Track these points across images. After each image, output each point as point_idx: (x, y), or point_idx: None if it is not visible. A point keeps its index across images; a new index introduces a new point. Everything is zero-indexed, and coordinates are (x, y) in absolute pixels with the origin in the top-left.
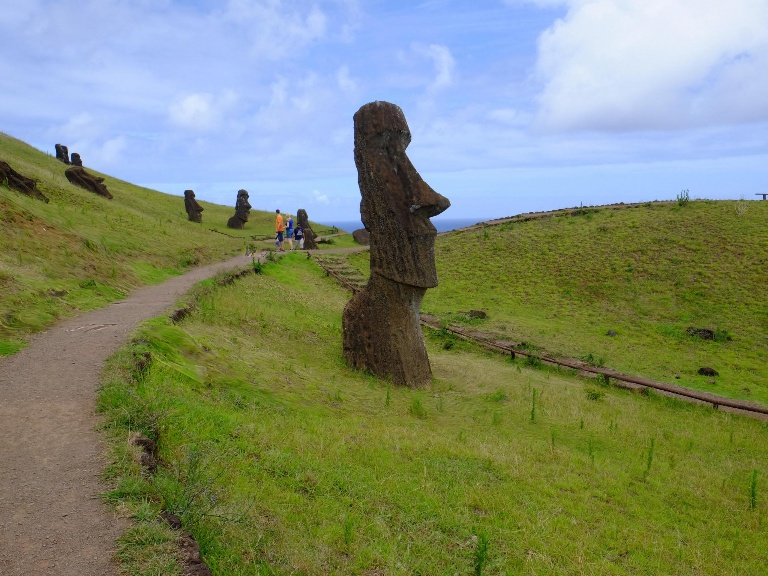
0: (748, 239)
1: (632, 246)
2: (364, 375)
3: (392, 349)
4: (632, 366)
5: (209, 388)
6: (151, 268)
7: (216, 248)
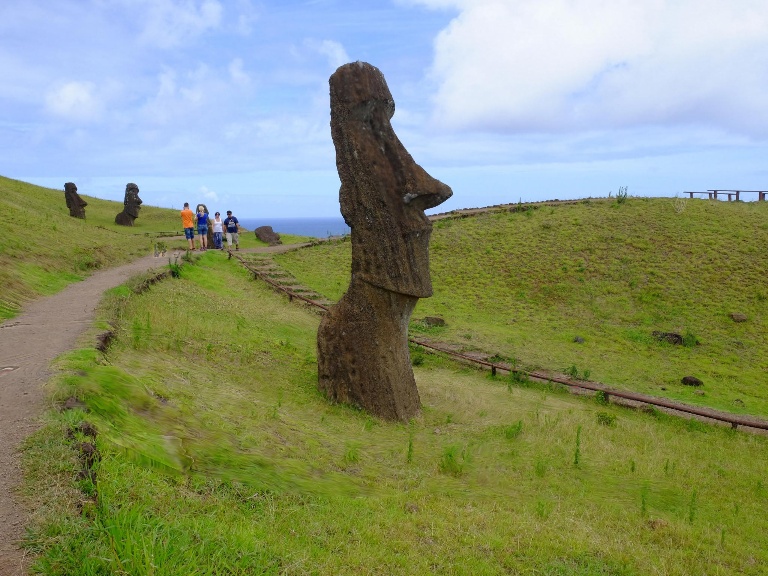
0: (693, 237)
1: (579, 245)
2: (349, 410)
3: (381, 375)
4: (613, 377)
5: None
6: (43, 272)
7: (119, 247)
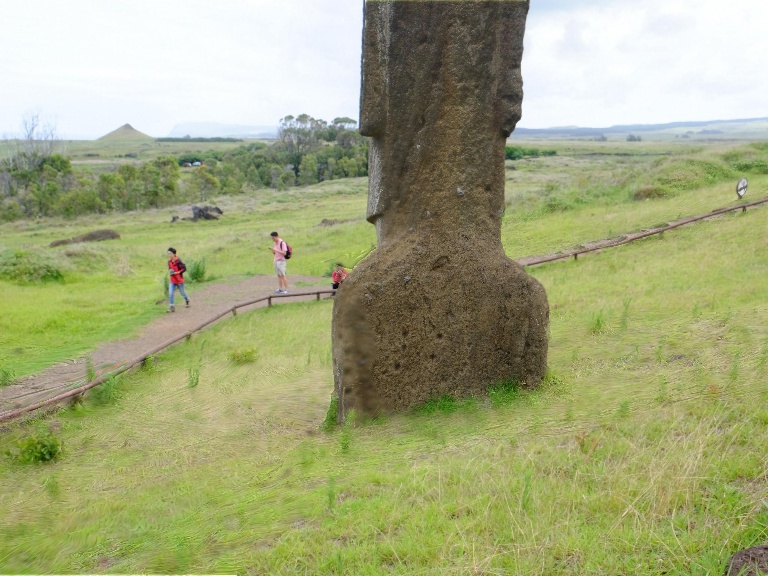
0: None
1: None
2: None
3: None
4: None
5: None
6: None
7: None
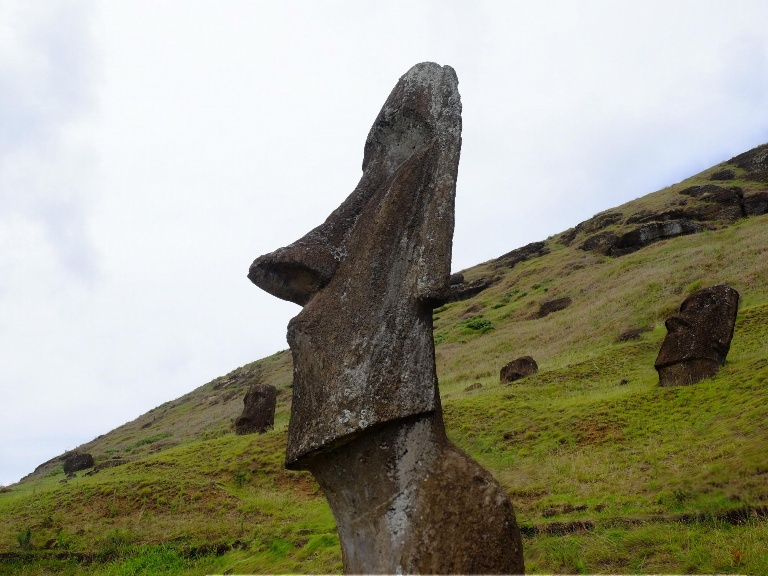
0: None
1: None
2: None
3: None
4: None
5: (211, 573)
6: None
7: None
